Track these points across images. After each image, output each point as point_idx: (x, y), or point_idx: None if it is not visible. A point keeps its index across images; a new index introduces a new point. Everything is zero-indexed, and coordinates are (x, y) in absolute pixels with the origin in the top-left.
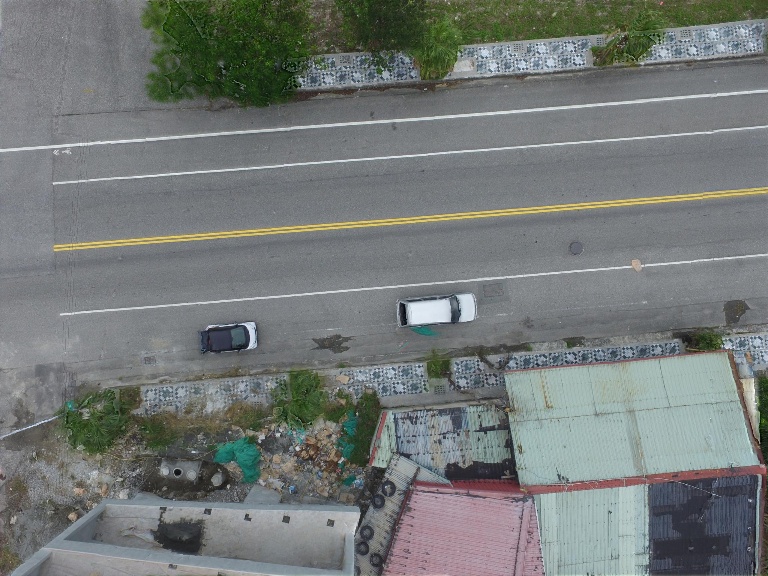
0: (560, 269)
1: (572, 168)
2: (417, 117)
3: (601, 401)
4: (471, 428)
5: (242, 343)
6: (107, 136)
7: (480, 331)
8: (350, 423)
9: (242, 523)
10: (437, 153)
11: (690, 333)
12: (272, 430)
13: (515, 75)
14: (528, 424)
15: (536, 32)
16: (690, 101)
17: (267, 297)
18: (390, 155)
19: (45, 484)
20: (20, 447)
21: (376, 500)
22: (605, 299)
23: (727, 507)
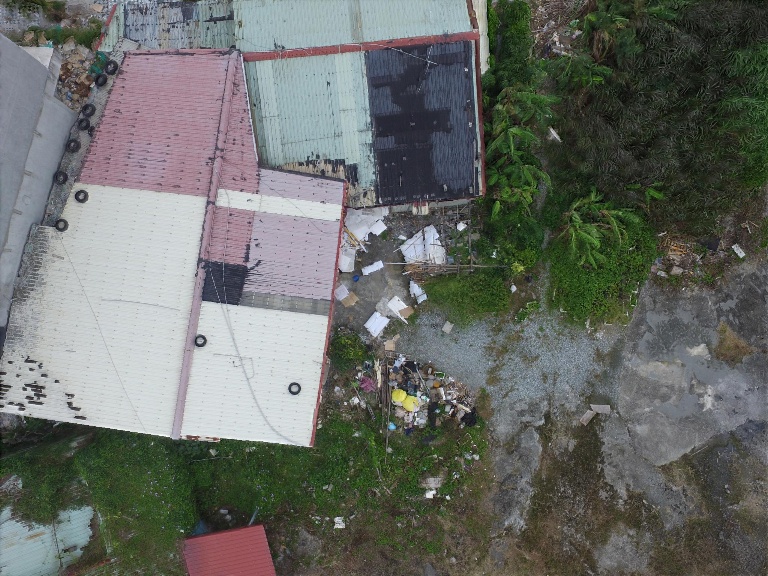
0: None
1: None
2: None
3: None
4: (202, 19)
5: None
6: None
7: None
8: None
9: None
10: None
11: None
12: None
13: None
14: (251, 3)
15: None
16: None
17: None
18: None
19: None
20: None
21: (100, 81)
22: None
23: (444, 76)
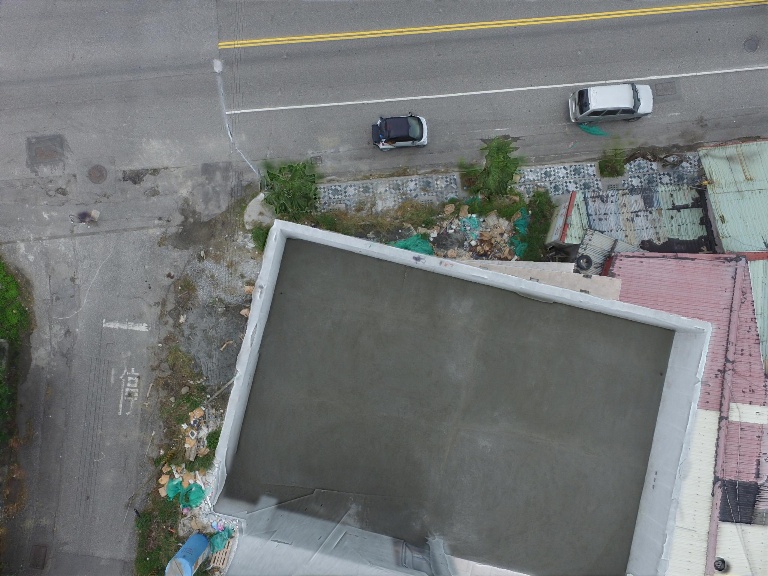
0: (734, 67)
1: None
2: None
3: None
4: (663, 207)
5: (415, 136)
6: None
7: (652, 131)
8: (523, 221)
9: None
10: None
11: None
12: (444, 227)
13: None
14: (728, 196)
15: None
16: None
17: (434, 96)
18: None
19: (214, 283)
20: (188, 246)
21: None
22: None
23: None
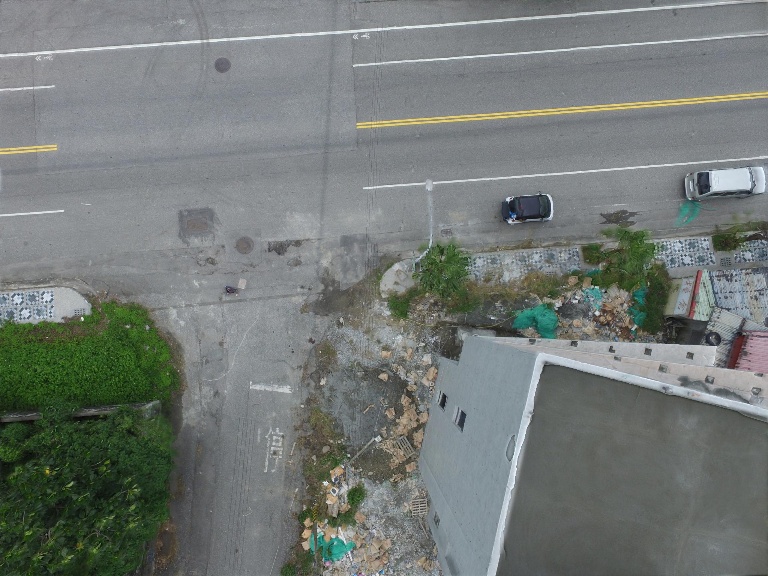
0: None
1: None
2: (697, 4)
3: None
4: None
5: (542, 213)
6: (402, 22)
7: (761, 207)
8: (642, 292)
9: None
10: (717, 38)
11: None
12: (569, 298)
13: None
14: None
15: None
16: None
17: (557, 173)
18: (672, 39)
19: (352, 348)
20: (328, 313)
21: None
22: None
23: None
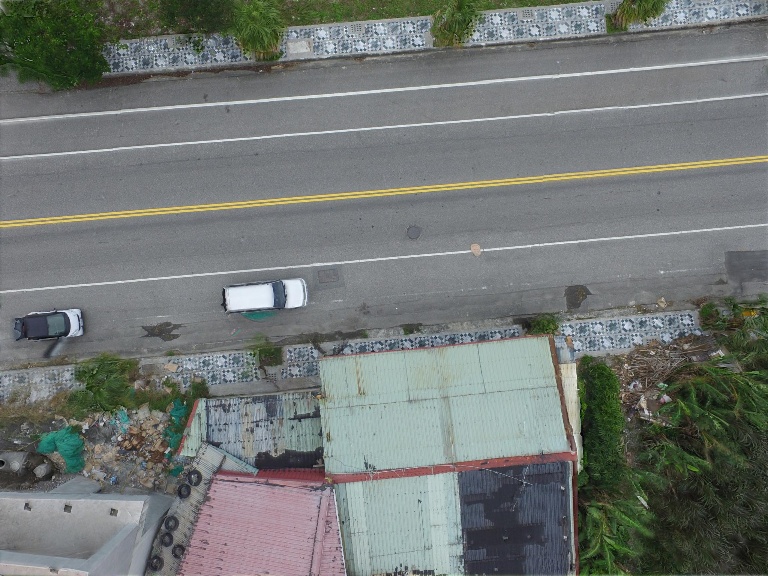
0: (397, 254)
1: (410, 151)
2: (251, 99)
3: (415, 387)
4: (286, 416)
5: (63, 330)
6: None
7: (315, 318)
8: (177, 412)
9: (21, 513)
10: (271, 136)
11: (530, 319)
12: (96, 420)
13: (353, 56)
14: (339, 411)
15: (375, 12)
16: (532, 82)
17: (95, 284)
18: (223, 138)
19: None
20: None
21: (183, 490)
22: (443, 285)
23: (539, 495)
